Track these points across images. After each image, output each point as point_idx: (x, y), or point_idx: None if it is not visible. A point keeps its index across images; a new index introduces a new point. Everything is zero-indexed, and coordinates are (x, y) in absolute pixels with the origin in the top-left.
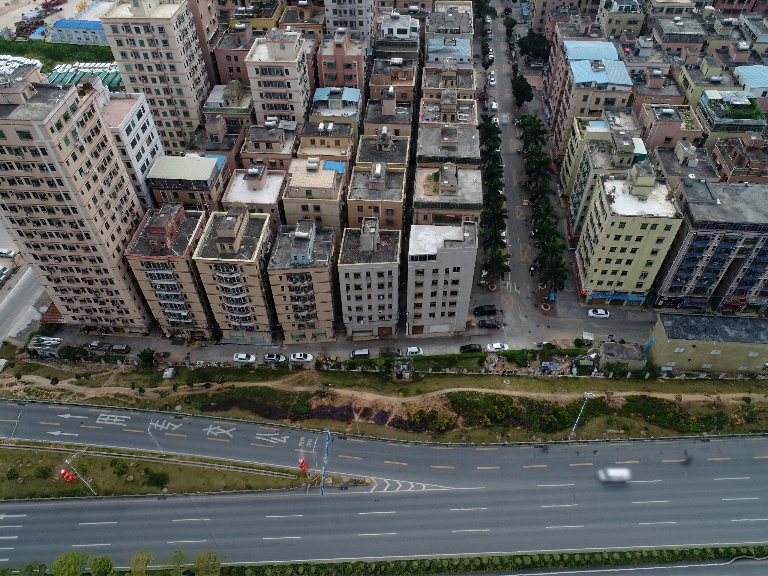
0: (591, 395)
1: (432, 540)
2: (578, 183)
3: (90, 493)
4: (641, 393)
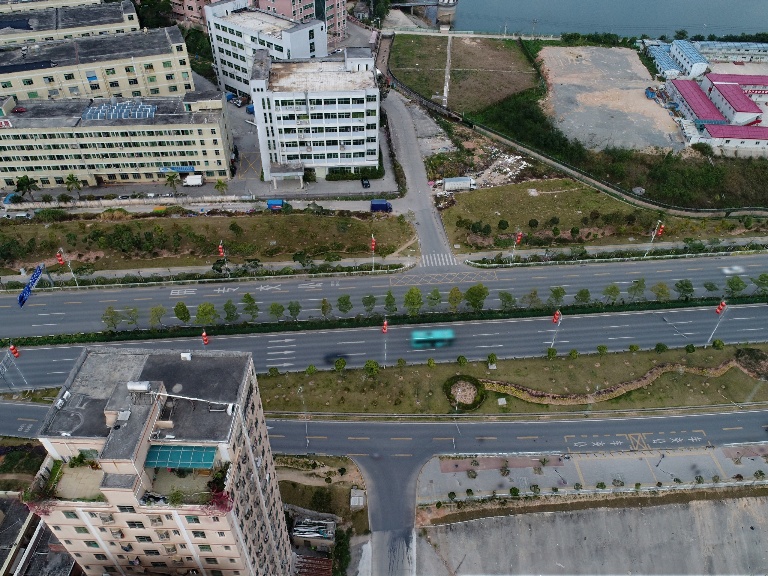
0: None
1: None
2: None
3: None
4: None
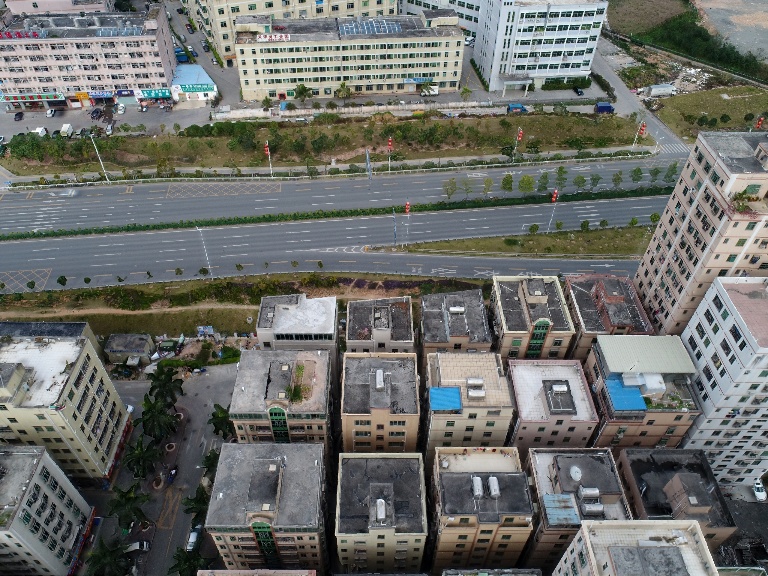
0: (179, 309)
1: (323, 227)
2: (50, 532)
3: (551, 234)
4: (134, 312)
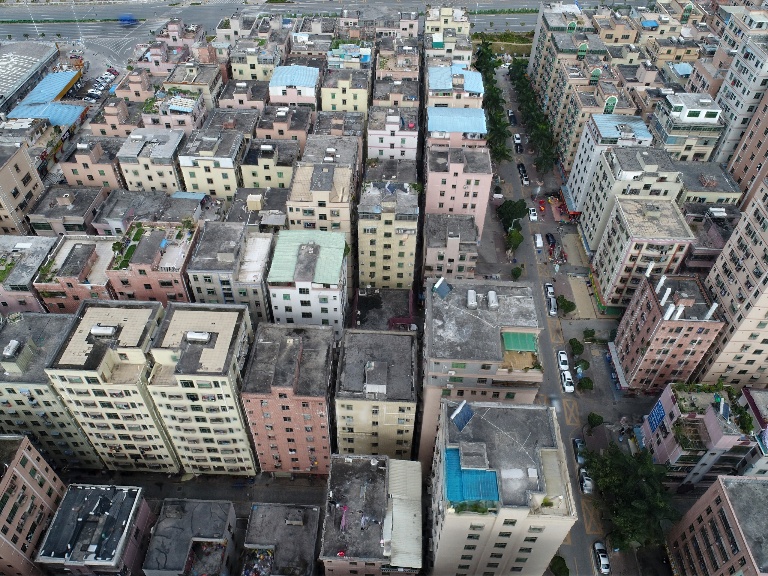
0: None
1: None
2: None
3: None
4: None
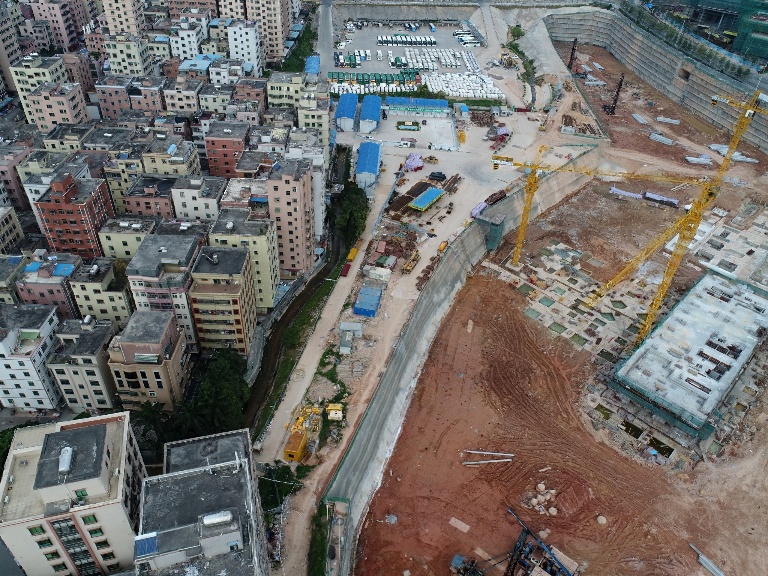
0: None
1: None
2: None
3: None
4: None
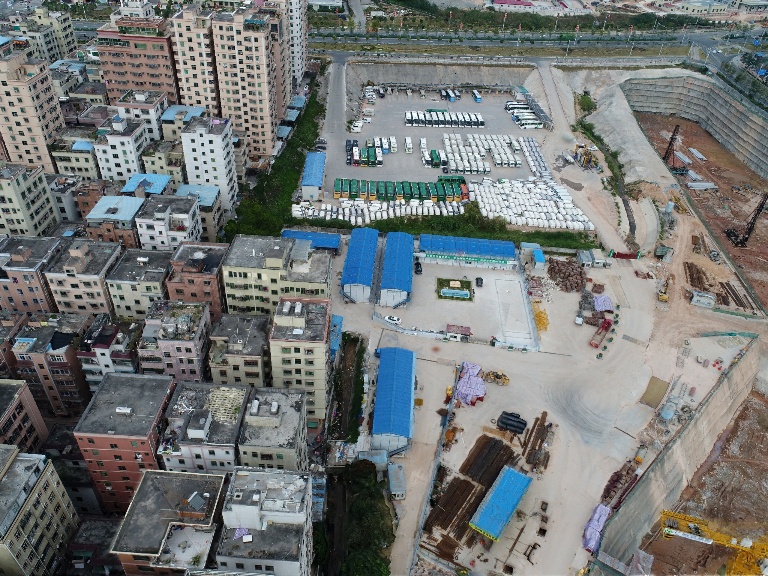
0: None
1: None
2: None
3: None
4: None
